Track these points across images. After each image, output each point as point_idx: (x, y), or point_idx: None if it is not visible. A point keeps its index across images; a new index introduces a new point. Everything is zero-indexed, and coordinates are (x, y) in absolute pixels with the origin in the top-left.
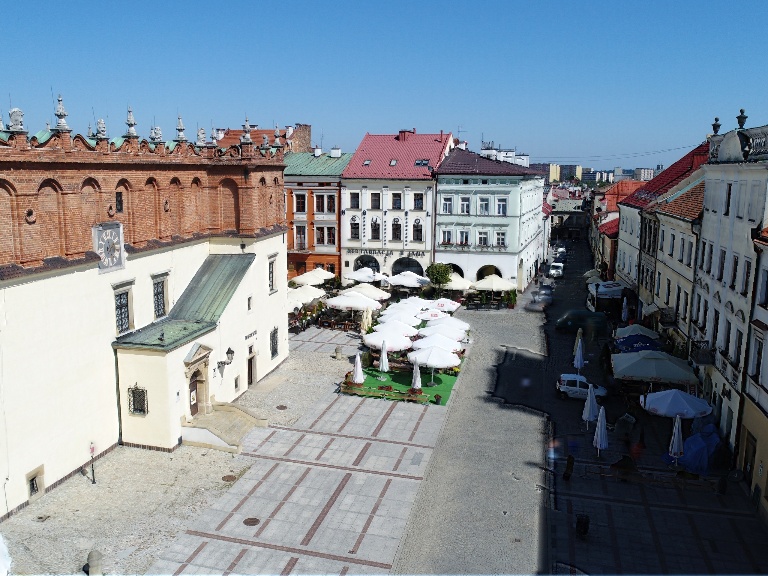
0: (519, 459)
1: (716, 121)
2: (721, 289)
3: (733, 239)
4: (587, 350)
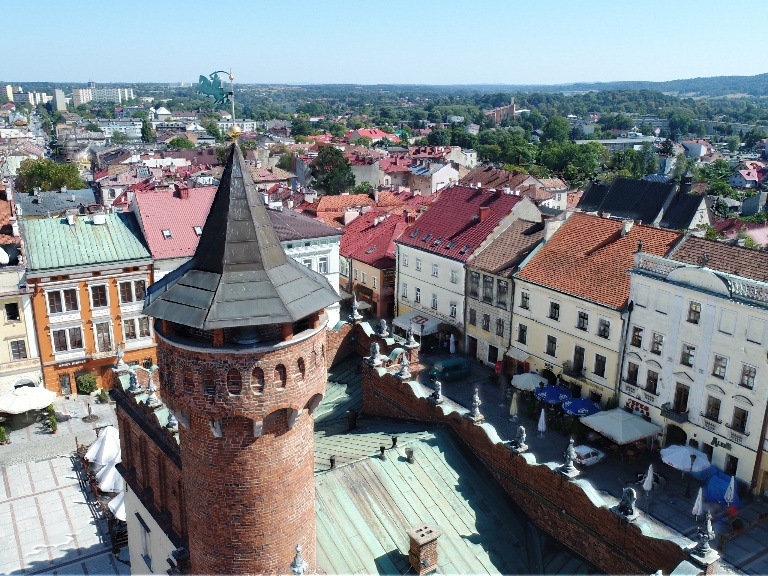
0: None
1: (641, 242)
2: (693, 372)
3: (713, 344)
4: (490, 400)
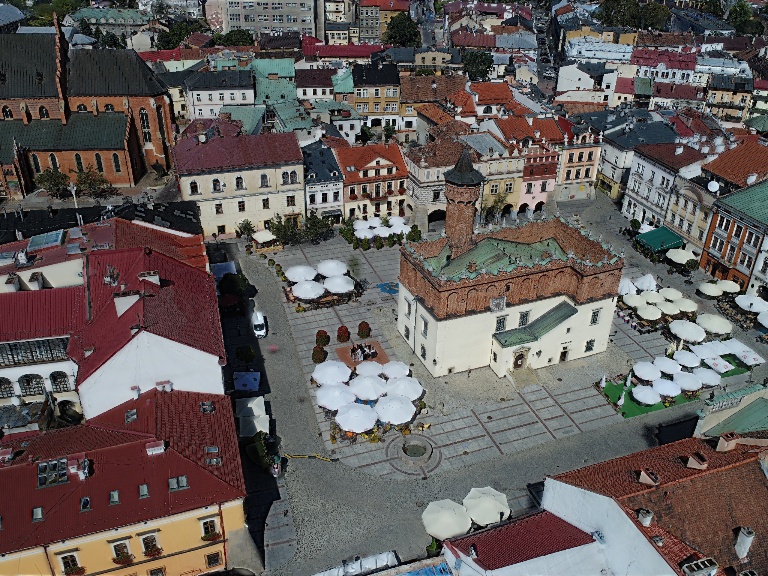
0: (601, 457)
1: None
2: None
3: None
4: None
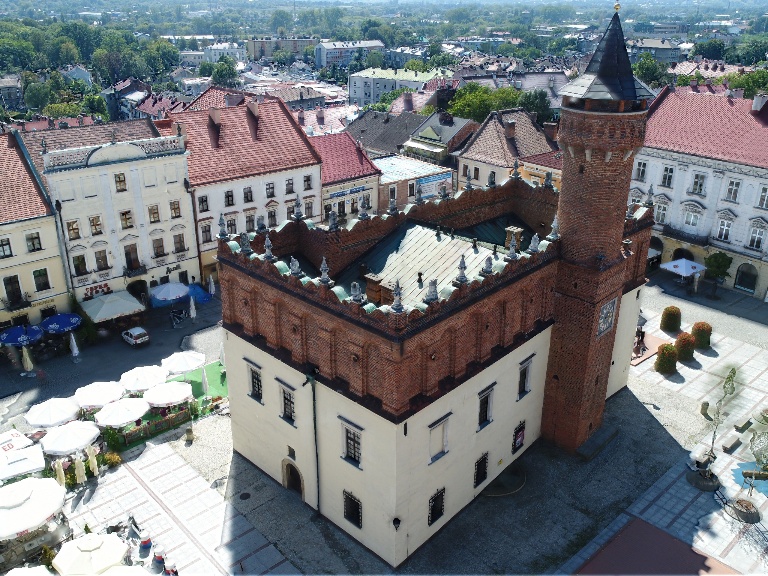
0: None
1: None
2: None
3: None
4: None
